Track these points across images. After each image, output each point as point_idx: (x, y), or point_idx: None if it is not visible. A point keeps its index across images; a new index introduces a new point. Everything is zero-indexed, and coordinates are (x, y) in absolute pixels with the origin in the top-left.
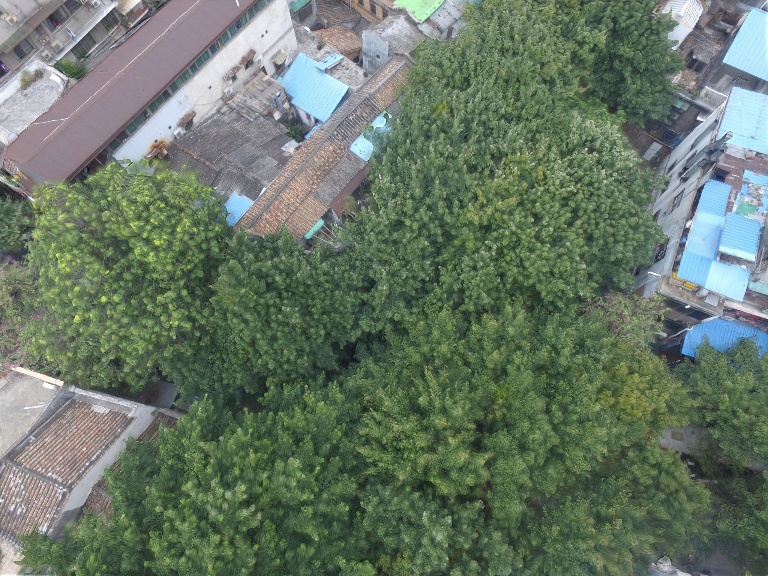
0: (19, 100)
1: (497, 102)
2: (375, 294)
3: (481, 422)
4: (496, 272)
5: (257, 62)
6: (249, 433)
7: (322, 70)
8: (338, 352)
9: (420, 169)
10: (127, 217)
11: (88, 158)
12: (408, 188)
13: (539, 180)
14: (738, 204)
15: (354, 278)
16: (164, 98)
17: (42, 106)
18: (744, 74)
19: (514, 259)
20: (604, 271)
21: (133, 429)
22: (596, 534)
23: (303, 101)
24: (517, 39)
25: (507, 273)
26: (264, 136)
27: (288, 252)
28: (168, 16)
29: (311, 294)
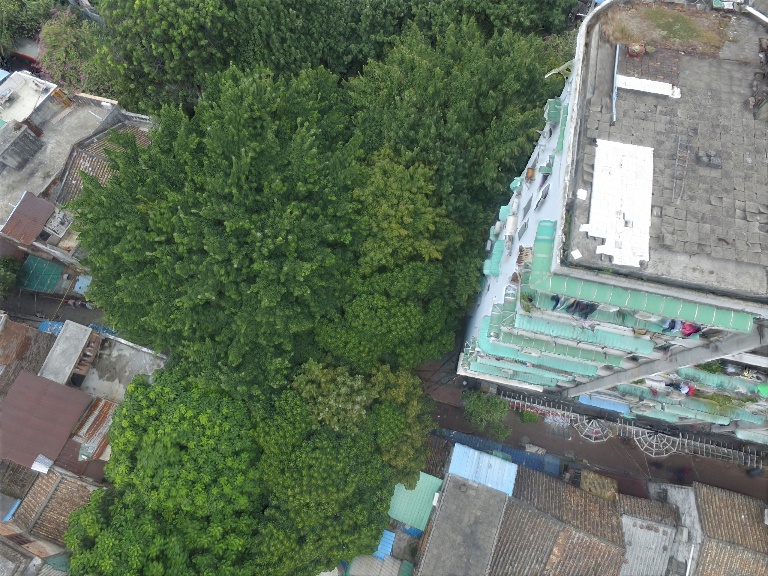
0: None
1: None
2: (361, 15)
3: None
4: (455, 5)
5: None
6: None
7: None
8: None
9: None
10: None
11: None
12: None
13: None
14: None
15: (345, 11)
16: None
17: None
18: None
19: None
20: (543, 18)
21: None
22: None
23: None
24: None
25: (463, 0)
26: None
27: None
28: None
29: (311, 21)
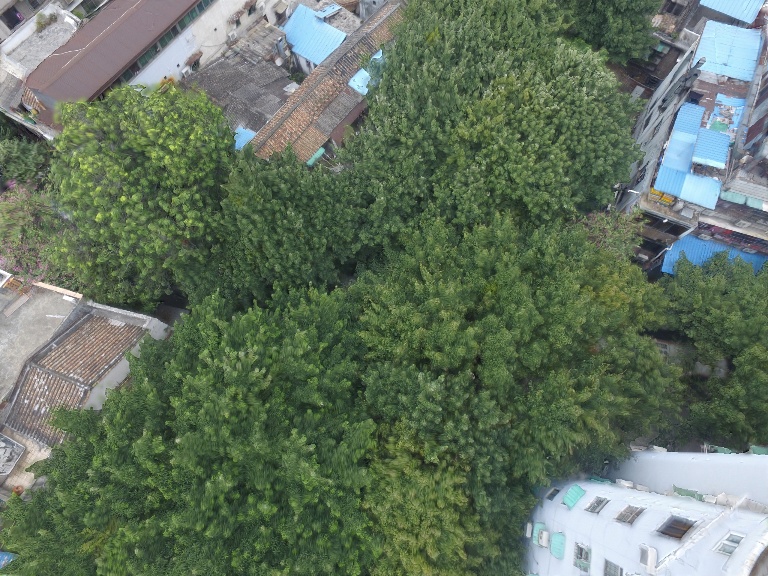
0: (35, 42)
1: (486, 31)
2: (373, 205)
3: (472, 311)
4: (486, 187)
5: (259, 9)
6: None
7: (321, 18)
8: (339, 273)
9: (414, 89)
10: (143, 127)
11: (103, 85)
12: (403, 109)
13: (525, 101)
14: (711, 123)
15: (354, 194)
16: (173, 34)
17: (57, 47)
18: (720, 15)
19: (502, 173)
20: (588, 191)
21: None
22: (576, 394)
23: (303, 49)
24: None
25: (496, 186)
26: (267, 77)
27: None
28: None
29: (314, 208)
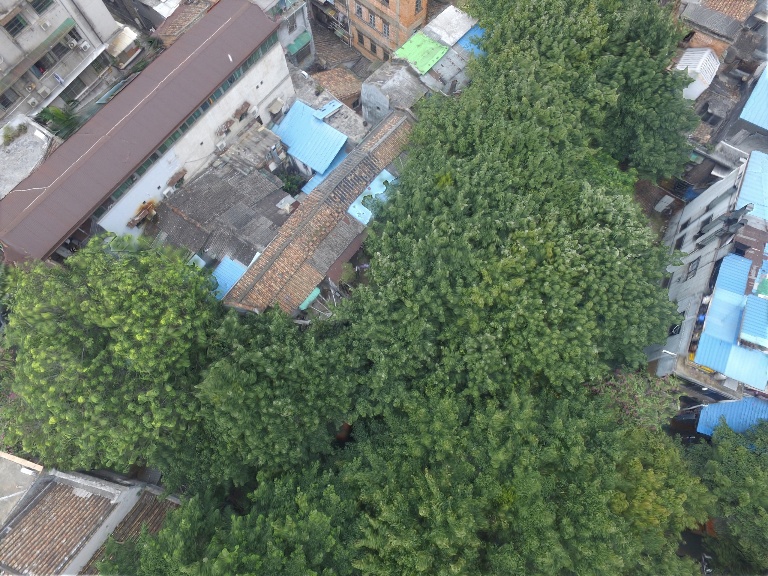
0: (1, 157)
1: (503, 171)
2: (373, 380)
3: (486, 531)
4: (502, 354)
5: (252, 113)
6: (236, 549)
7: (320, 119)
8: (334, 428)
9: (421, 247)
10: (108, 307)
11: (70, 229)
12: (409, 265)
13: (548, 257)
14: (759, 282)
15: (351, 360)
16: (152, 160)
17: (25, 164)
18: (762, 130)
19: (521, 342)
20: (616, 347)
21: (117, 513)
22: None
23: (300, 151)
24: (525, 102)
25: (514, 357)
26: (258, 192)
27: (281, 335)
28: (157, 72)
29: (305, 378)
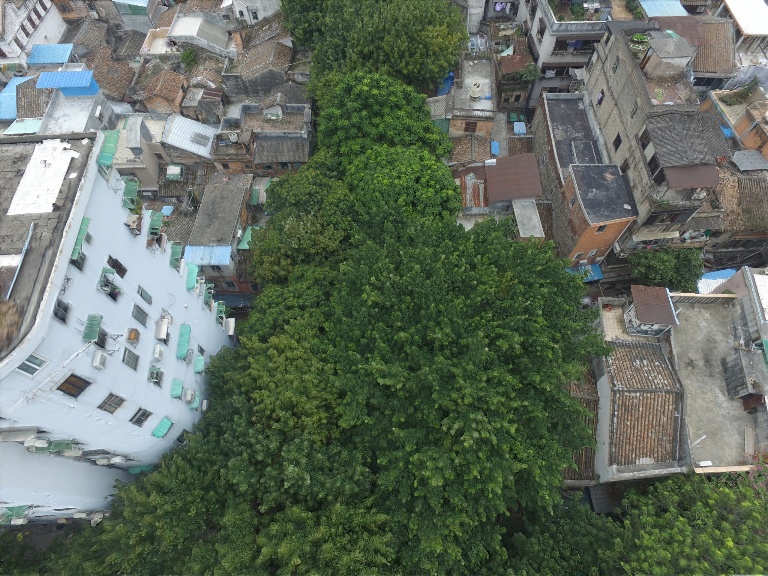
0: None
1: None
2: None
3: None
4: None
5: None
6: None
7: None
8: None
9: None
10: None
11: None
12: None
13: None
14: None
15: None
16: None
17: None
18: None
19: None
20: None
21: (604, 455)
22: (155, 521)
23: None
24: None
25: None
26: None
27: None
28: None
29: None
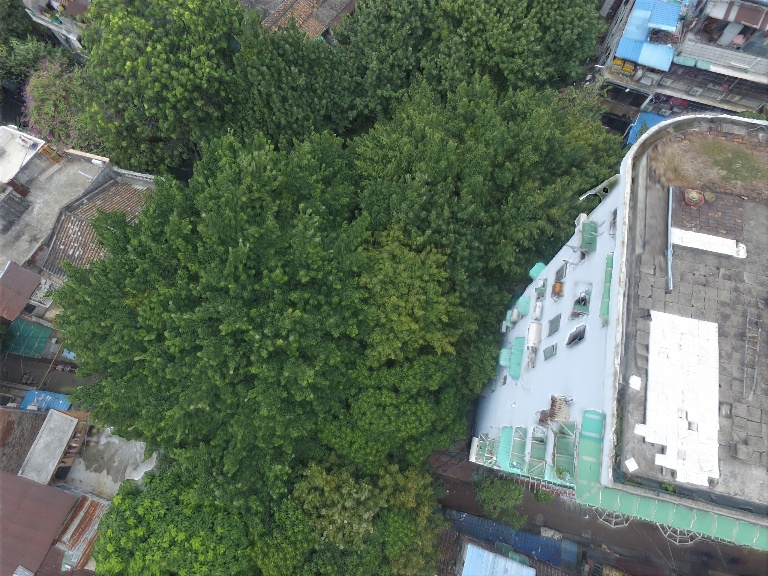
0: None
1: None
2: (367, 71)
3: None
4: (467, 58)
5: None
6: None
7: None
8: None
9: None
10: None
11: None
12: None
13: None
14: None
15: (350, 64)
16: None
17: None
18: None
19: (481, 44)
20: (559, 68)
21: None
22: None
23: None
24: None
25: (475, 54)
26: None
27: None
28: None
29: (314, 76)
